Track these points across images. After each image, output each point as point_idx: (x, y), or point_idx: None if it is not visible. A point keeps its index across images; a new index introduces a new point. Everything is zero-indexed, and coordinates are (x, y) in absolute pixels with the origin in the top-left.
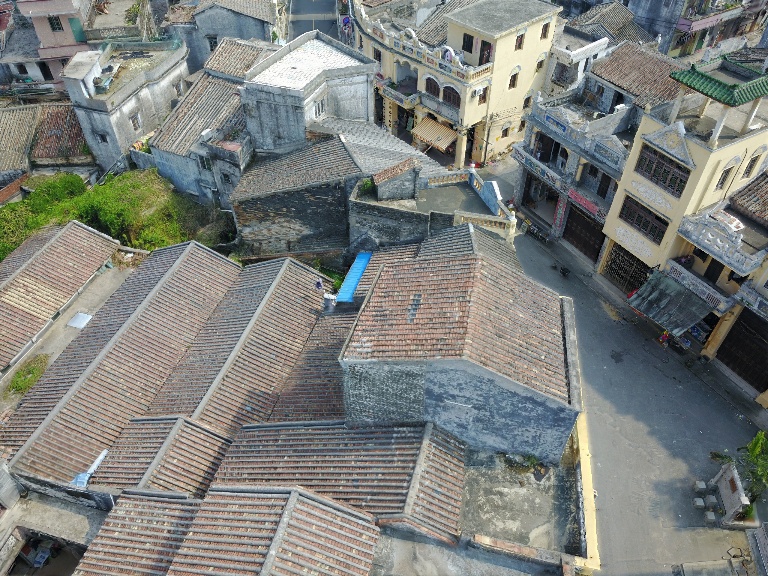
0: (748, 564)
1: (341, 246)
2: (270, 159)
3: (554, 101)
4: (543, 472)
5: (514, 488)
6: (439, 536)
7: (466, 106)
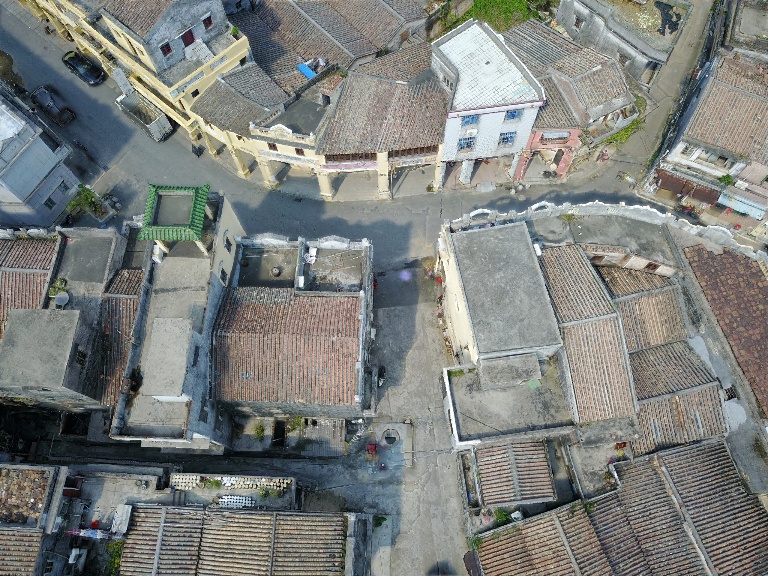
0: None
1: None
2: None
3: None
4: None
5: None
6: None
7: None
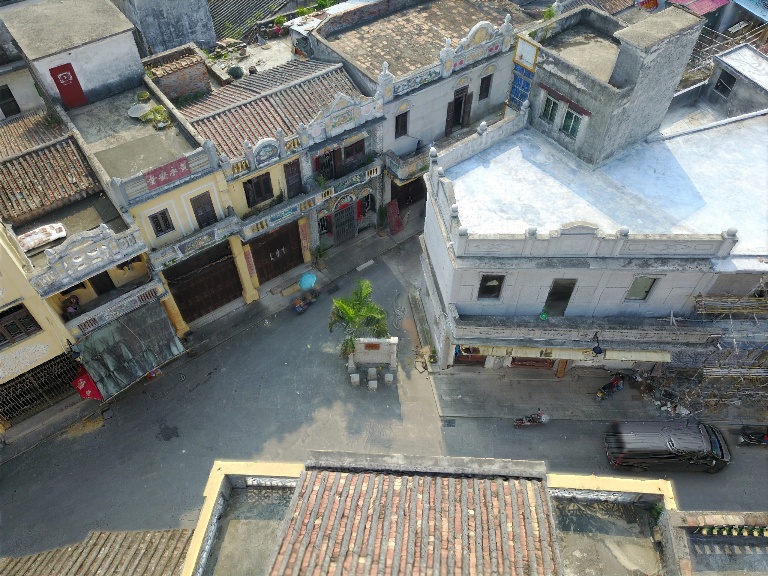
0: (479, 352)
1: None
2: None
3: None
4: None
5: None
6: None
7: None
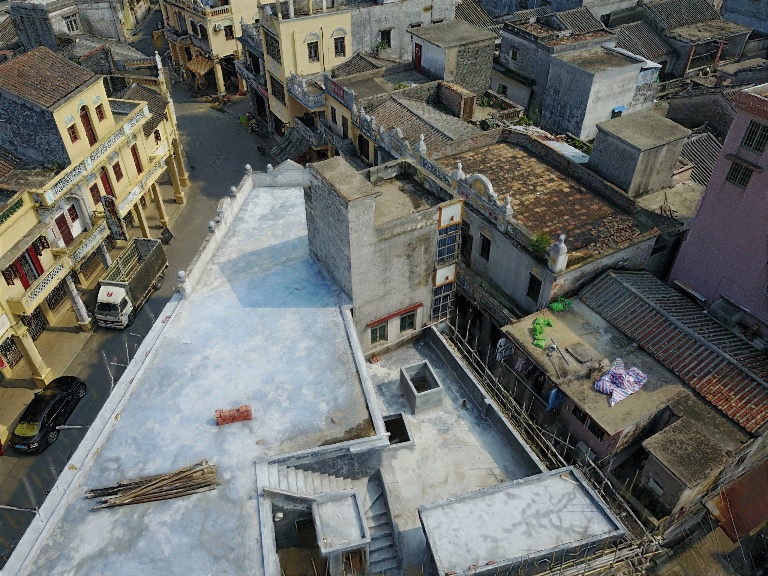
0: None
1: None
2: None
3: None
4: None
5: (37, 177)
6: None
7: (211, 38)
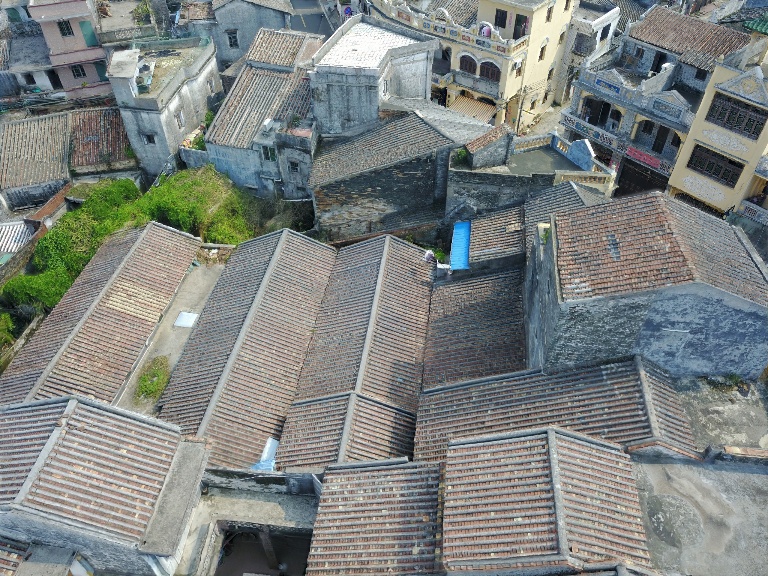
0: None
1: (434, 219)
2: (338, 143)
3: (597, 66)
4: (746, 388)
5: (727, 406)
6: (688, 454)
7: (507, 79)
